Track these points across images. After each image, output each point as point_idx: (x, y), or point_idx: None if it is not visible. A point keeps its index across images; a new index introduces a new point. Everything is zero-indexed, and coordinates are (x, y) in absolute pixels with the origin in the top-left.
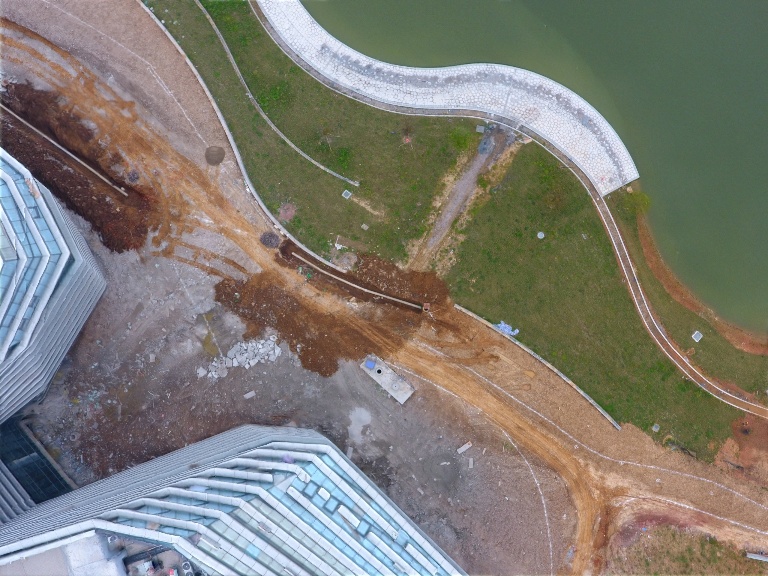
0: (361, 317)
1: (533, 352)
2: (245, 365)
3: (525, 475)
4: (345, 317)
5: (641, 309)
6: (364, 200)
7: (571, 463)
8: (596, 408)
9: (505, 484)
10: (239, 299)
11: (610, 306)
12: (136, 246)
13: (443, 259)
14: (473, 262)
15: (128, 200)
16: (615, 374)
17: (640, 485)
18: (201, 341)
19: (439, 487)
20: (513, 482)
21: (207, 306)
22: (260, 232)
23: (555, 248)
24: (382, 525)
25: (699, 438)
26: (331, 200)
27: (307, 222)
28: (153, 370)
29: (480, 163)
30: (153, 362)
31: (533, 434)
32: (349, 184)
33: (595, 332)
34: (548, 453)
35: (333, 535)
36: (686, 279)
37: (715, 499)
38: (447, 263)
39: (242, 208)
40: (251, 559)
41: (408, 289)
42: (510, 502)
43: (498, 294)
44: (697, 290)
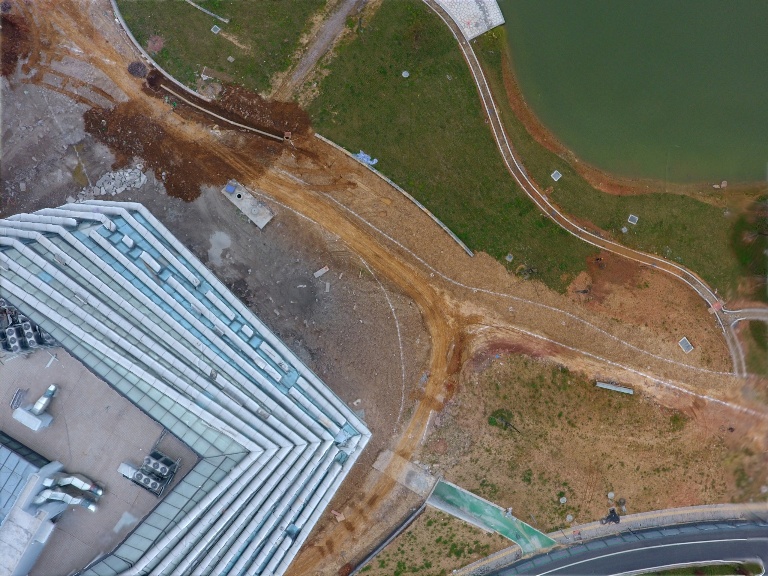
0: (224, 145)
1: (390, 180)
2: (112, 192)
3: (380, 300)
4: (208, 144)
5: (503, 149)
6: (232, 35)
7: (427, 291)
8: (450, 235)
9: (360, 308)
10: (106, 127)
11: (471, 143)
12: (5, 73)
13: (306, 91)
14: (336, 95)
15: (3, 33)
16: (471, 205)
17: (494, 314)
18: (71, 171)
19: (295, 309)
20: (368, 306)
21: (77, 136)
22: (128, 62)
23: (419, 86)
24: (184, 273)
25: (552, 269)
26: (200, 34)
27: (175, 54)
28: (23, 199)
29: (350, 5)
30: (24, 191)
31: (390, 262)
32: (219, 20)
33: (454, 165)
34: (404, 281)
35: (132, 276)
36: (548, 122)
37: (567, 329)
38: (310, 95)
39: (111, 38)
40: (38, 279)
41: (269, 116)
42: (364, 325)
43: (359, 126)
44: (558, 132)
